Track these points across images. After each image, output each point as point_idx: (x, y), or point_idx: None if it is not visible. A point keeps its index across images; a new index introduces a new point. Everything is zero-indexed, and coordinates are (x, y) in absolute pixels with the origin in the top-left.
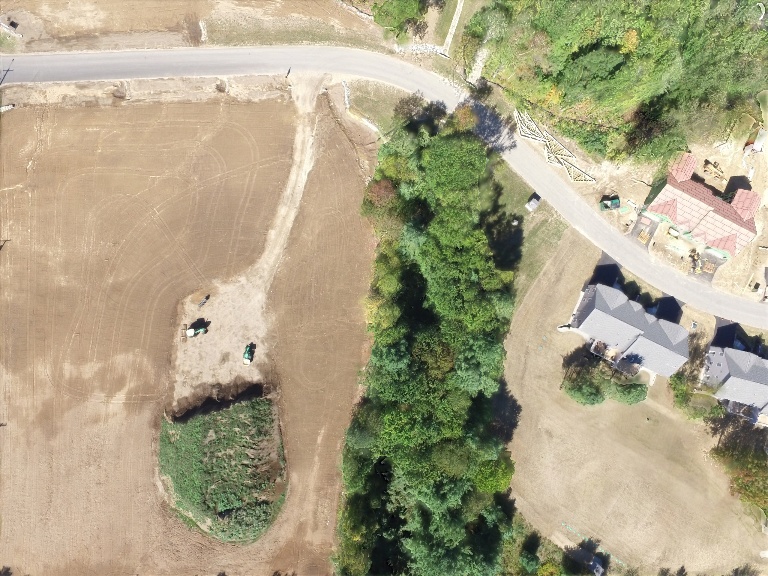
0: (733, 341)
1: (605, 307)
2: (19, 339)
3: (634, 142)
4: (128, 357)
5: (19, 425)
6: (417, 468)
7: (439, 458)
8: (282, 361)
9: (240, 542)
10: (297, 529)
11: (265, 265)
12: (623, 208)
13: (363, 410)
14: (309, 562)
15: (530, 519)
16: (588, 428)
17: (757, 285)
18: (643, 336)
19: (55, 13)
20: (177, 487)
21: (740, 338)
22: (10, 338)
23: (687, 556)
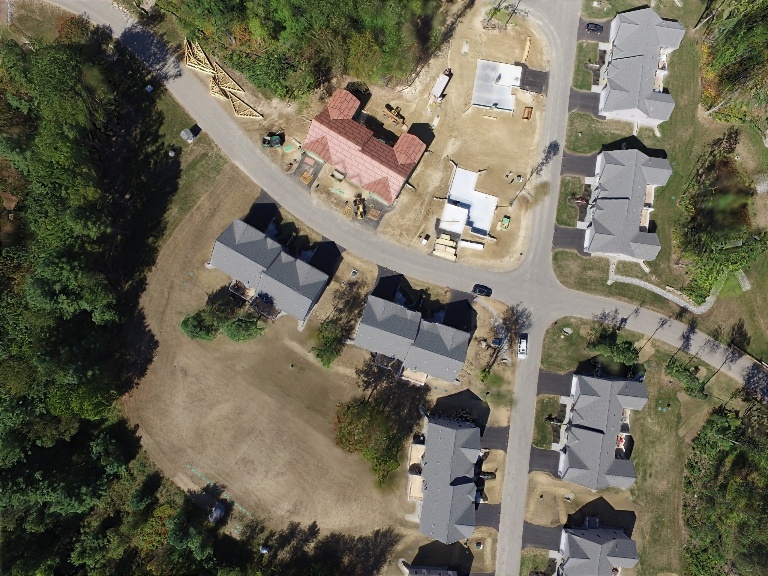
0: (395, 293)
1: (230, 240)
2: None
3: None
4: None
5: None
6: None
7: None
8: None
9: None
10: None
11: None
12: (288, 146)
13: None
14: None
15: (154, 458)
16: (224, 369)
17: (427, 237)
18: (265, 273)
19: None
20: None
21: (402, 290)
22: None
23: (320, 511)
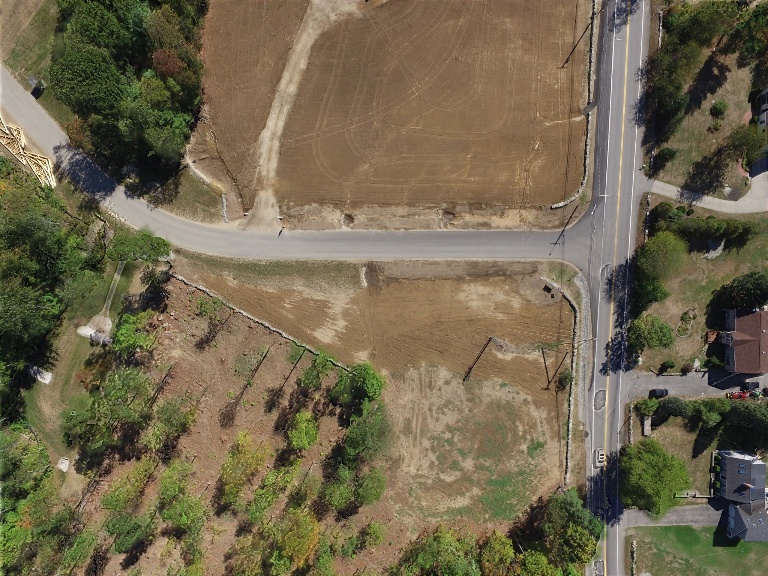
0: None
1: None
2: None
3: None
4: None
5: None
6: None
7: None
8: None
9: None
10: None
11: (311, 32)
12: None
13: None
14: None
15: None
16: None
17: None
18: None
19: (507, 300)
20: None
21: None
22: None
23: None
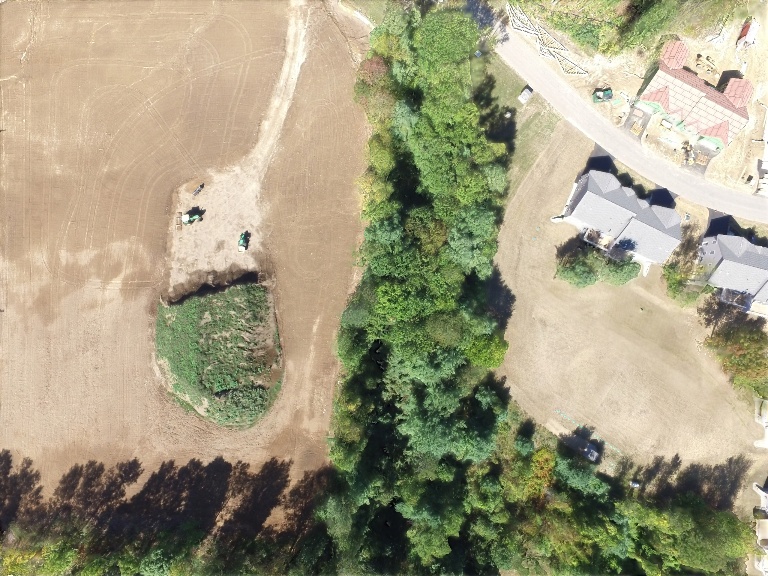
0: (726, 233)
1: (598, 190)
2: (15, 227)
3: (626, 36)
4: (124, 244)
5: (17, 311)
6: (411, 337)
7: (432, 327)
8: (277, 250)
9: (237, 427)
10: (293, 416)
11: (259, 155)
12: (616, 100)
13: (357, 292)
14: (306, 449)
15: (525, 407)
16: (582, 317)
17: (750, 178)
18: (636, 218)
19: None
20: (174, 367)
21: (733, 230)
22: (6, 226)
23: (681, 444)
